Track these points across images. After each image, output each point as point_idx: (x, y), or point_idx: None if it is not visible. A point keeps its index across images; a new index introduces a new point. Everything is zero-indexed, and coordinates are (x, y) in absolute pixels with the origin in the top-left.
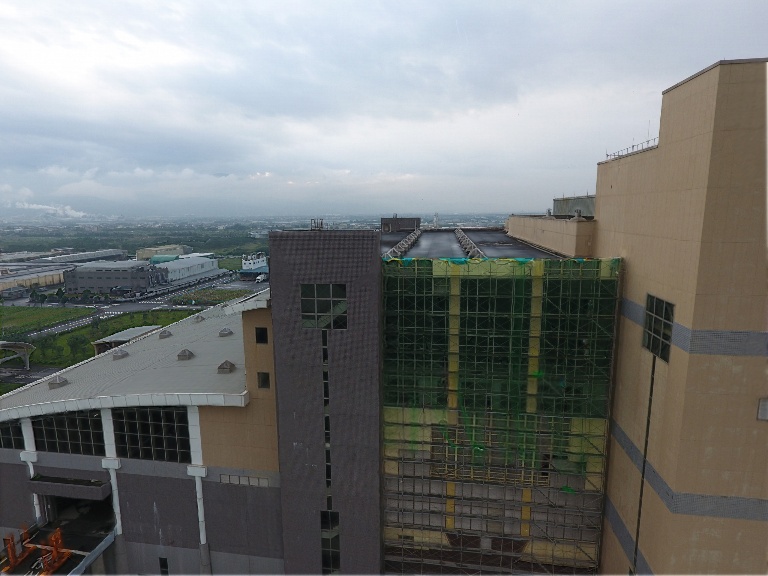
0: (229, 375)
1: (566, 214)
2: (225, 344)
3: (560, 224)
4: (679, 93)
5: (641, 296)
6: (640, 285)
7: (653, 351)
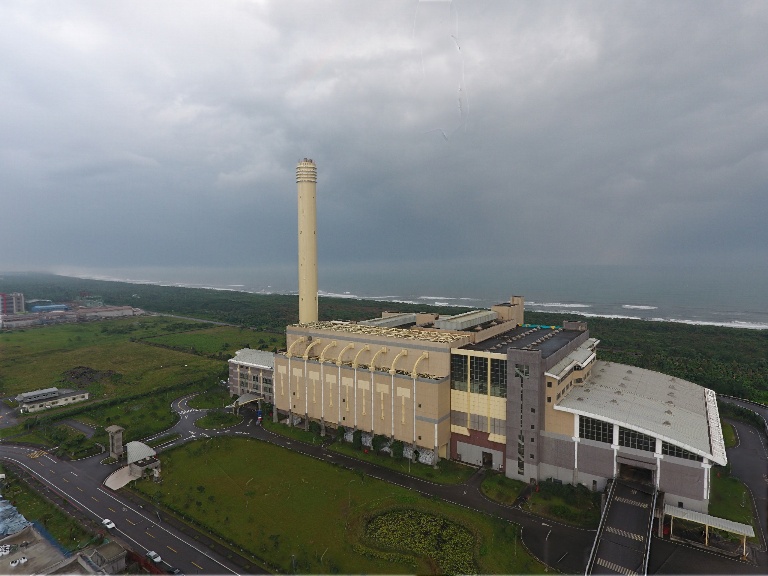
0: None
1: None
2: None
3: None
4: None
5: None
6: None
7: None
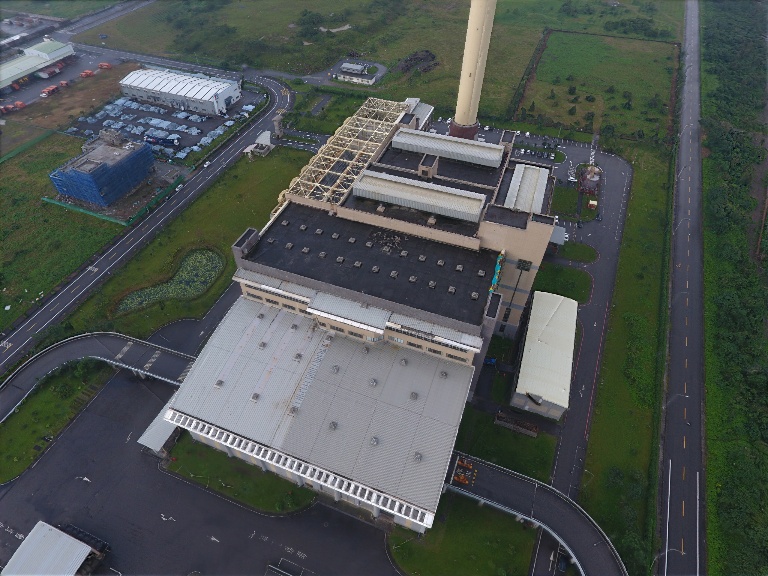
0: (450, 374)
1: (382, 201)
2: (396, 381)
3: (461, 237)
4: (539, 225)
5: (516, 259)
6: (515, 257)
7: (521, 269)
